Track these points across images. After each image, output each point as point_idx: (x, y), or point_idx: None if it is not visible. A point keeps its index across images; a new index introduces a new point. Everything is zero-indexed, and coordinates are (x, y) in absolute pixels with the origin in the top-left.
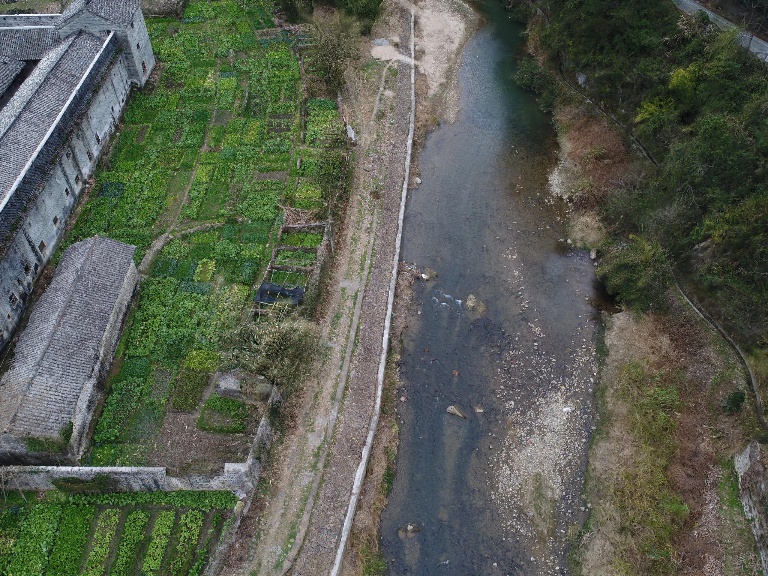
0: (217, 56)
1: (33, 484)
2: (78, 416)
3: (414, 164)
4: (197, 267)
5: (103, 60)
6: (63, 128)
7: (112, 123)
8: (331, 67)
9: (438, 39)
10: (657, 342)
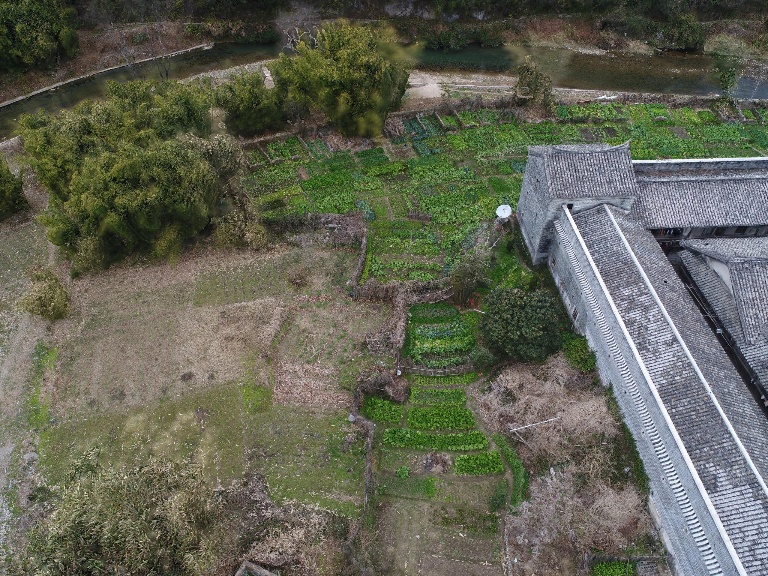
0: None
1: None
2: None
3: None
4: None
5: None
6: None
7: None
8: None
9: None
10: (722, 41)
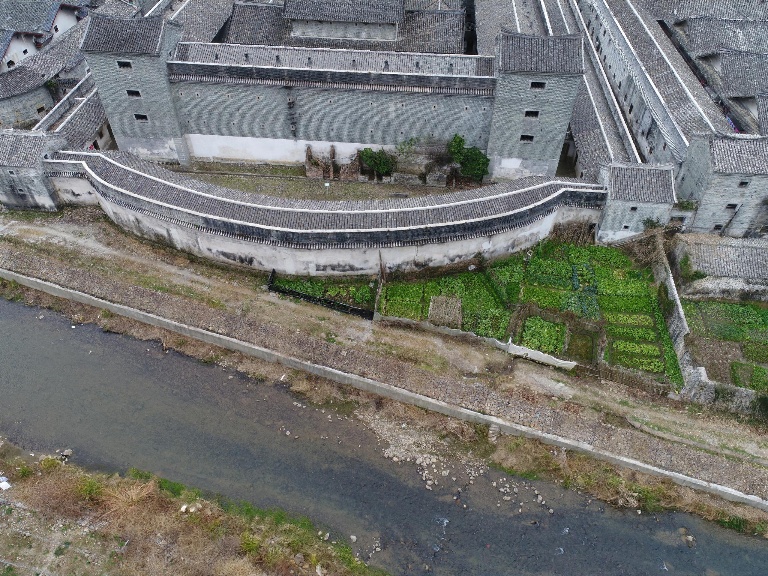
0: None
1: (659, 277)
2: (714, 284)
3: None
4: None
5: None
6: None
7: None
8: None
9: None
10: None
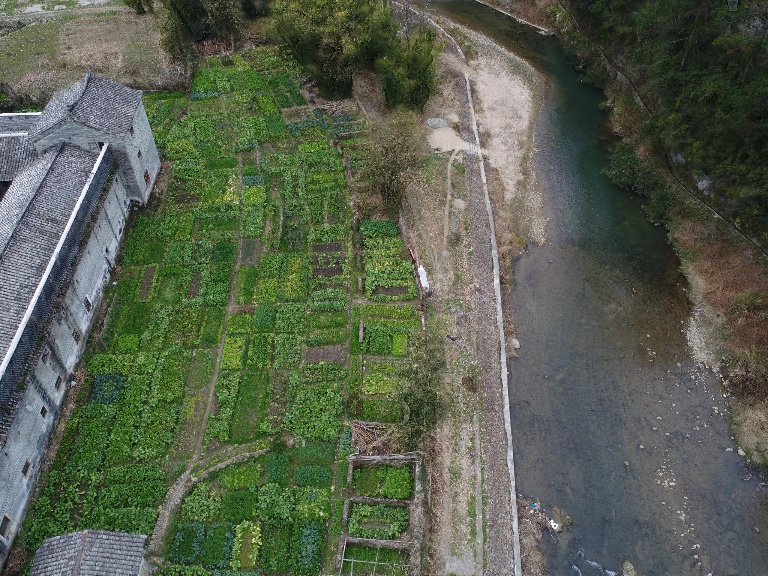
0: (238, 150)
1: None
2: None
3: (506, 315)
4: (234, 538)
5: (94, 190)
6: (37, 322)
7: (107, 270)
8: (392, 182)
9: (503, 114)
10: None
